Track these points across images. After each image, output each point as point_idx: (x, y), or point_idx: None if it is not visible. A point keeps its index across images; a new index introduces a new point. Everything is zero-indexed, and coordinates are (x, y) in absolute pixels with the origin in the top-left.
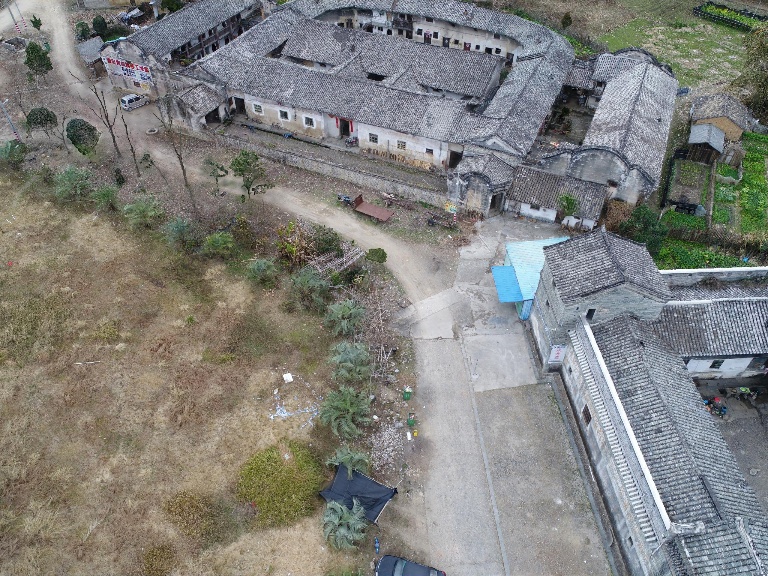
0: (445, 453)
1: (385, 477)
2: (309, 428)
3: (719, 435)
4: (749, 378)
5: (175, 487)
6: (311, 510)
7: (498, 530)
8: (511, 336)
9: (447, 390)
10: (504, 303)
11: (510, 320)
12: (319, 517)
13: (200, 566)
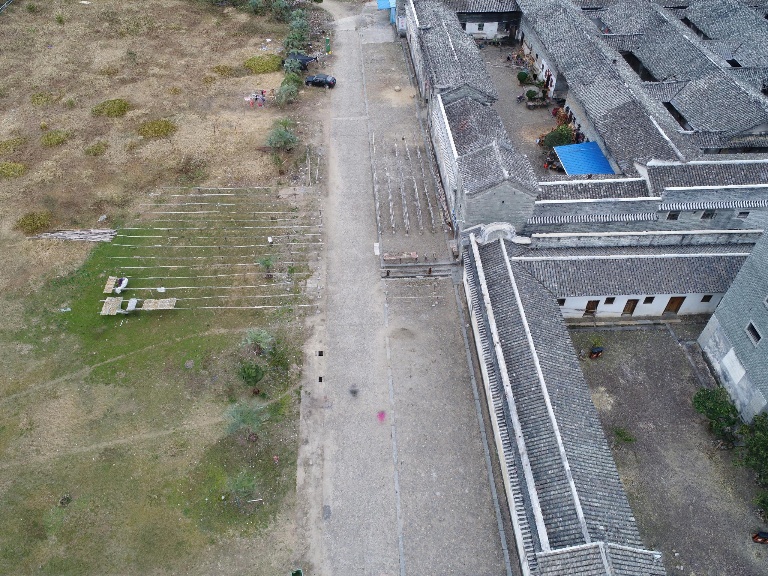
0: (343, 58)
1: (314, 64)
2: (279, 52)
3: (461, 28)
4: (501, 39)
5: (215, 65)
6: (278, 69)
7: (363, 75)
8: (385, 29)
9: (348, 43)
10: (384, 19)
11: (386, 24)
12: (282, 72)
13: (228, 81)
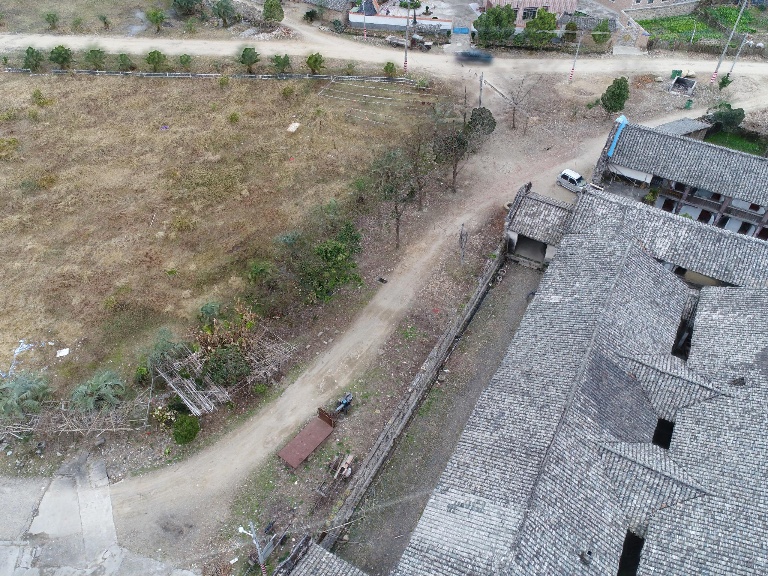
0: None
1: None
2: None
3: None
4: None
5: None
6: None
7: None
8: None
9: None
10: None
11: None
12: None
13: None
